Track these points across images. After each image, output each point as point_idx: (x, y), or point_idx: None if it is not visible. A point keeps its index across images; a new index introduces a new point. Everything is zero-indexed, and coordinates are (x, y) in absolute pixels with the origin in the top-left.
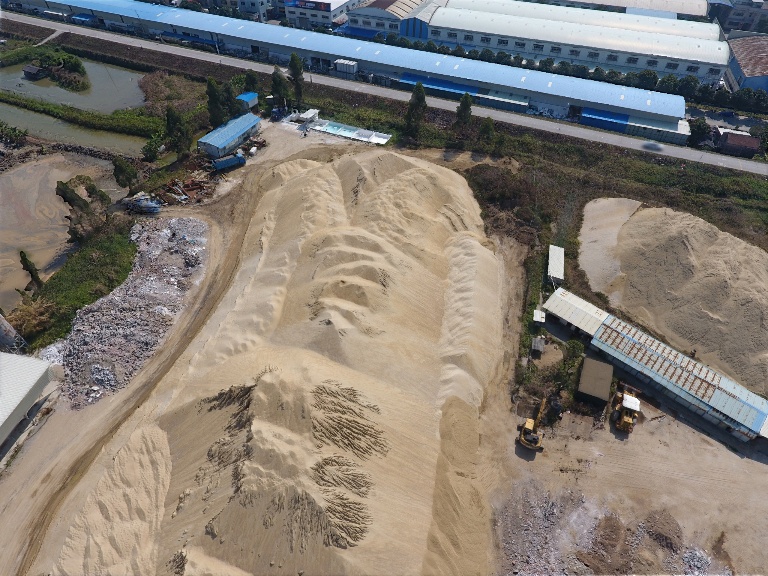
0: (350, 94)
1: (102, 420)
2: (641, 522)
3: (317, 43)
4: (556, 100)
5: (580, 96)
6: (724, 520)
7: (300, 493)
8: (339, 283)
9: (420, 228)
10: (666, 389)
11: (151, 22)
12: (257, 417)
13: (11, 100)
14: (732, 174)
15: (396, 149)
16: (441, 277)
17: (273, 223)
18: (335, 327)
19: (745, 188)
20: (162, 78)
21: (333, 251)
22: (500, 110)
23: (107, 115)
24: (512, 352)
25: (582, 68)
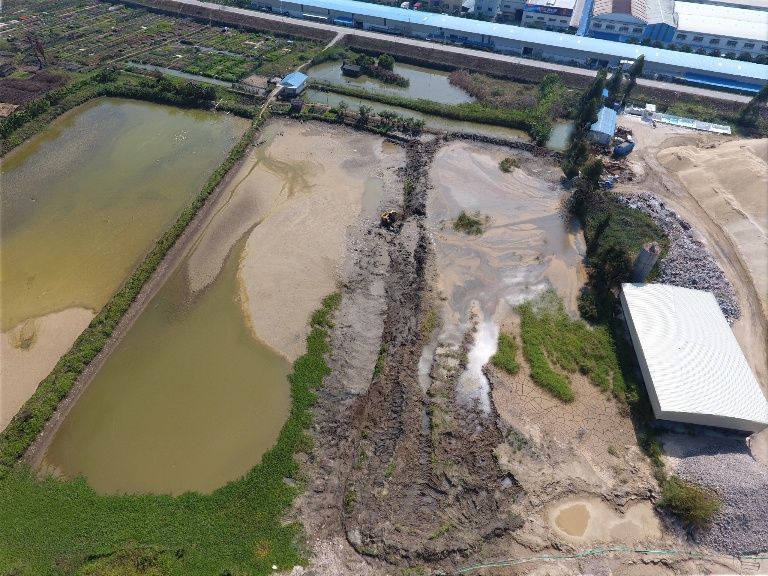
0: (659, 91)
1: (752, 337)
2: None
3: (595, 45)
4: None
5: None
6: None
7: None
8: None
9: None
10: None
11: (420, 25)
12: None
13: (362, 95)
14: None
15: (743, 138)
16: None
17: (730, 196)
18: None
19: None
20: (466, 76)
21: None
22: None
23: (466, 108)
24: None
25: None
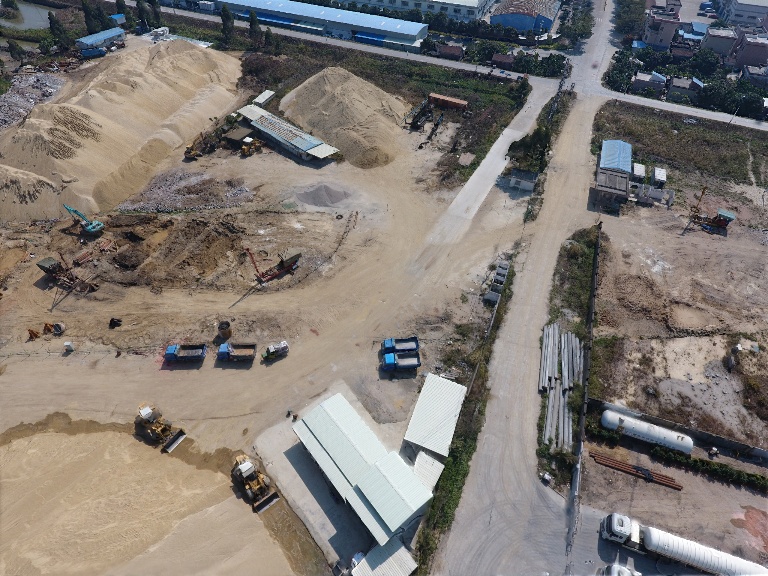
0: (199, 21)
1: None
2: (226, 180)
3: None
4: (342, 27)
5: (355, 23)
6: (268, 181)
7: (38, 134)
8: (104, 82)
9: (182, 75)
10: (280, 142)
11: None
12: (32, 118)
13: None
14: (423, 65)
15: None
16: (186, 98)
17: None
18: (89, 93)
19: (425, 72)
20: (73, 12)
21: (112, 74)
22: (298, 31)
23: (23, 30)
24: (211, 131)
25: (373, 8)
